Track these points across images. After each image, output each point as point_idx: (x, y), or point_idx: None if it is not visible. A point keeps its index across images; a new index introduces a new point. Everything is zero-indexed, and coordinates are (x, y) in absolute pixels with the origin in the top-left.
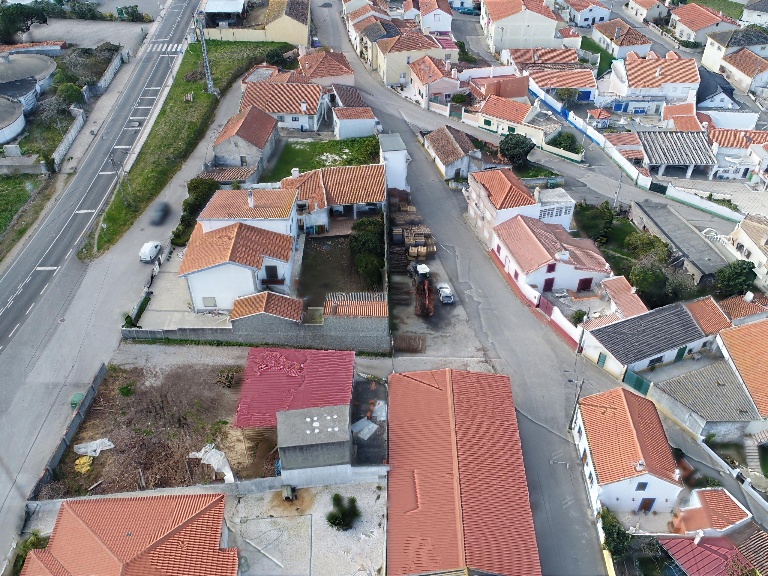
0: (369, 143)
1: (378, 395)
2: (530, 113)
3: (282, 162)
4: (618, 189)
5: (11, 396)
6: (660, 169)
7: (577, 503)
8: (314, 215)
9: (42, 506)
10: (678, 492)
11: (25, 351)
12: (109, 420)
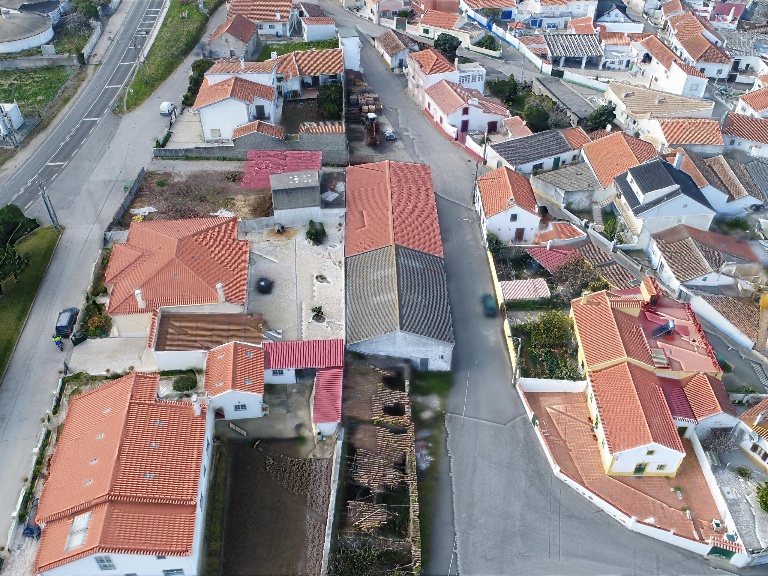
0: (331, 41)
1: (339, 179)
2: (459, 21)
3: (263, 56)
4: (522, 68)
5: (80, 187)
6: (560, 61)
7: (474, 238)
8: (290, 82)
9: (115, 235)
10: (538, 221)
11: (85, 163)
12: (152, 198)
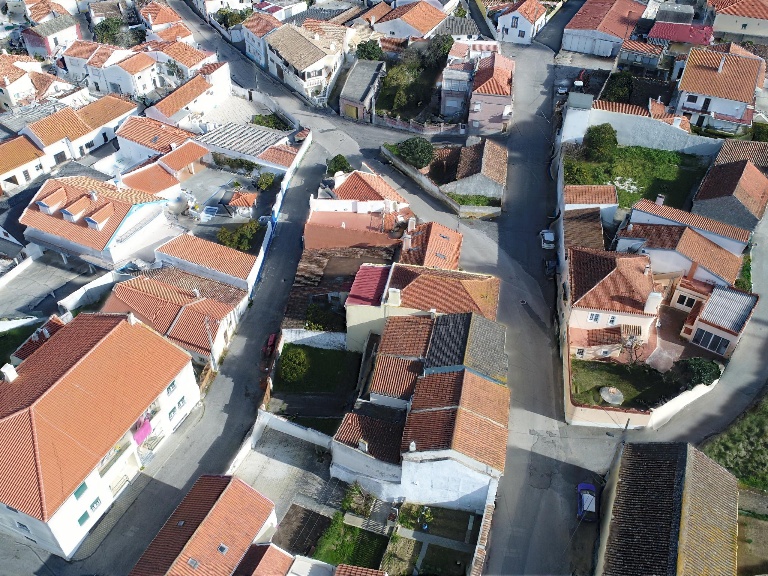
0: None
1: None
2: None
3: (684, 190)
4: None
5: None
6: None
7: None
8: None
9: None
10: None
11: None
12: None
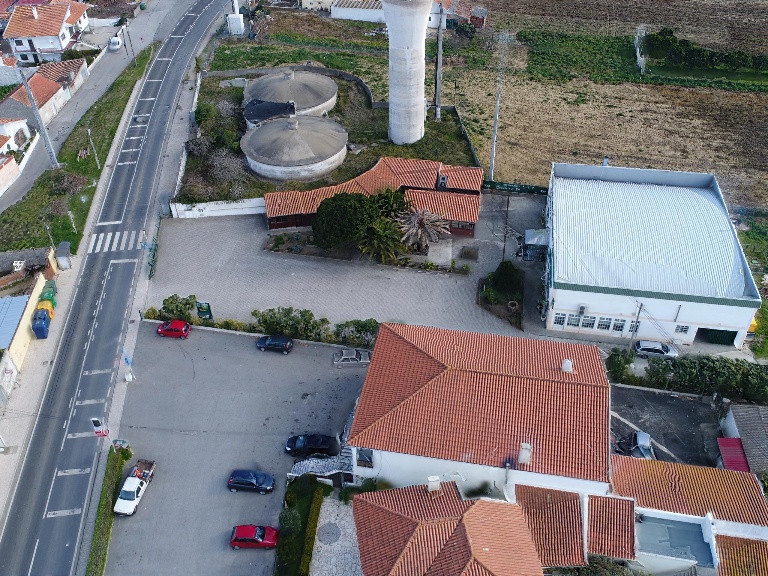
0: None
1: None
2: None
3: None
4: None
5: None
6: None
7: None
8: None
9: None
10: None
11: None
12: None
